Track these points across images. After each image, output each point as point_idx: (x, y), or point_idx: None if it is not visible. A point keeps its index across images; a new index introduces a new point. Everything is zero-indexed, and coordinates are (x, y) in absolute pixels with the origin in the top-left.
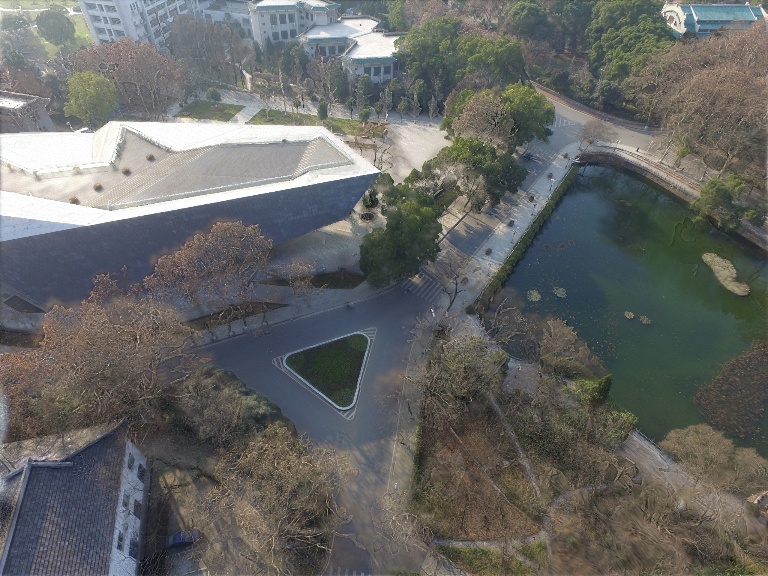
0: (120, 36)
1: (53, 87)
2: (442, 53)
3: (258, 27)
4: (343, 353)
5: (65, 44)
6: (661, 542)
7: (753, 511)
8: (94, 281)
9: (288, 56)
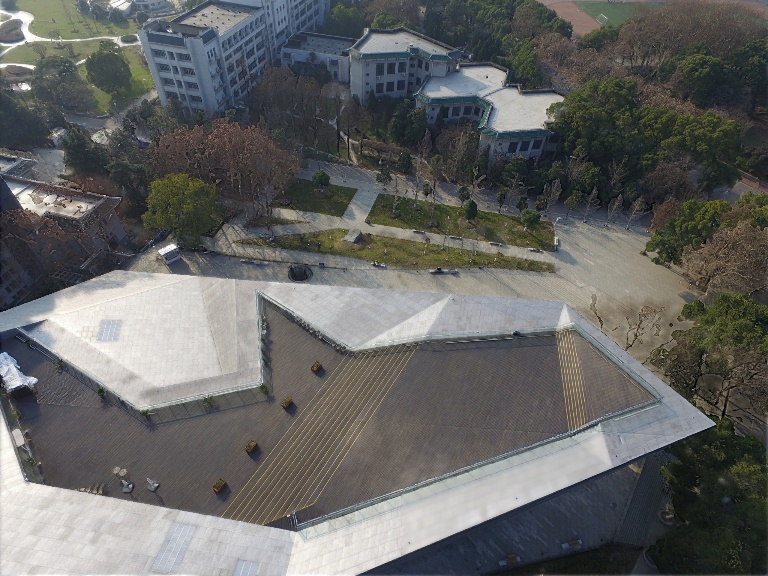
0: (191, 88)
1: (123, 178)
2: (621, 130)
3: (360, 78)
4: None
5: (118, 90)
6: None
7: None
8: None
9: (403, 119)
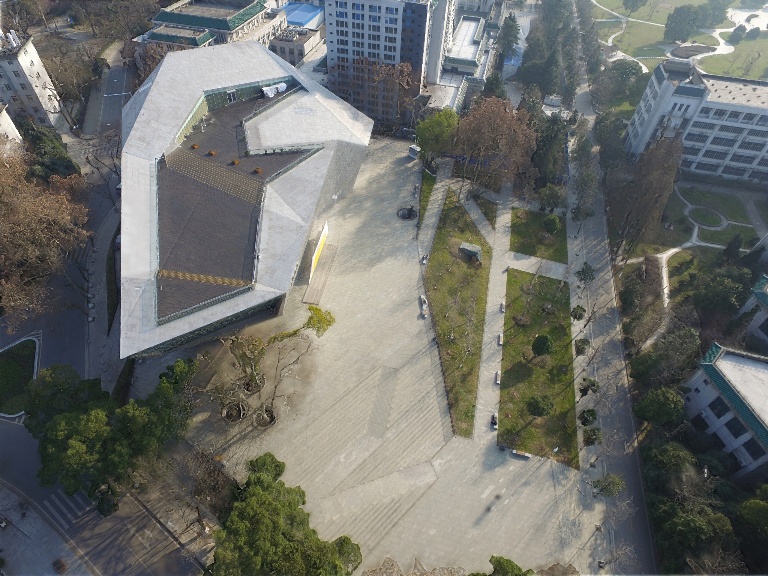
0: None
1: None
2: None
3: None
4: (8, 389)
5: None
6: None
7: None
8: (80, 177)
9: None
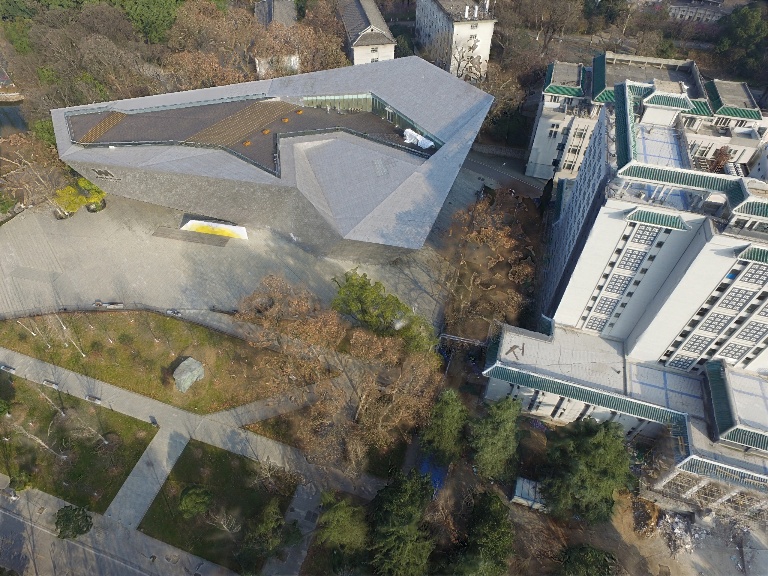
0: None
1: None
2: None
3: None
4: None
5: None
6: (86, 8)
7: (24, 90)
8: None
9: None
